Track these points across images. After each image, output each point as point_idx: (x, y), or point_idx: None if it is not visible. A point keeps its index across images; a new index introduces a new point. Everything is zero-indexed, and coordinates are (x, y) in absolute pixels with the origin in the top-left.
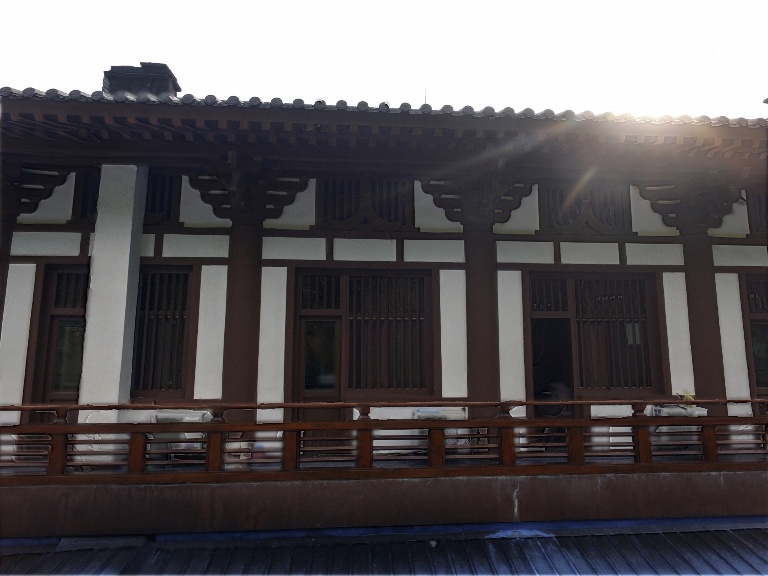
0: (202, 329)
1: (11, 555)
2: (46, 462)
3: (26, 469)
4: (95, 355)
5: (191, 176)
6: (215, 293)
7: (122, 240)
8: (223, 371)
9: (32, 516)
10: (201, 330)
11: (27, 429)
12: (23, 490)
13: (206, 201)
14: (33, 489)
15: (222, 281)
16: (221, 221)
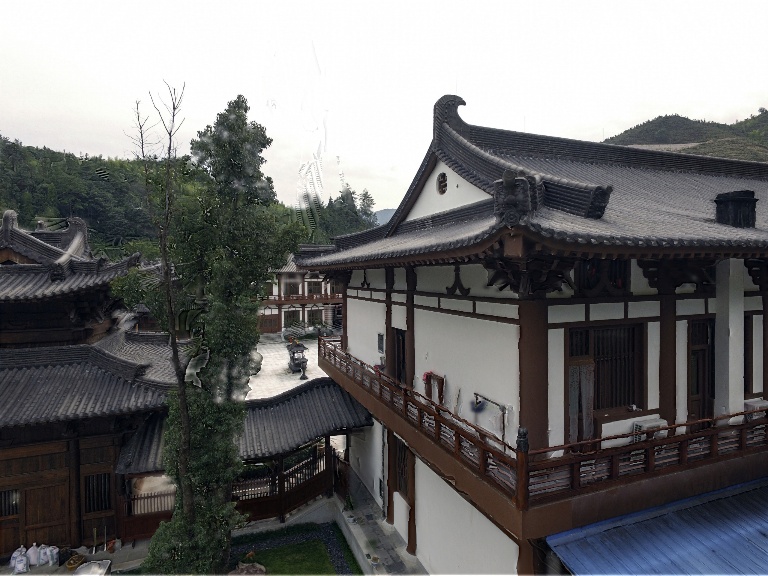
0: (754, 353)
1: (767, 486)
2: (764, 438)
3: (760, 443)
4: (734, 375)
5: (747, 259)
6: (759, 332)
7: (741, 306)
8: (763, 376)
9: (767, 466)
10: (754, 354)
11: (762, 422)
12: (764, 454)
13: (752, 275)
14: (767, 452)
15: (761, 324)
16: (756, 287)
